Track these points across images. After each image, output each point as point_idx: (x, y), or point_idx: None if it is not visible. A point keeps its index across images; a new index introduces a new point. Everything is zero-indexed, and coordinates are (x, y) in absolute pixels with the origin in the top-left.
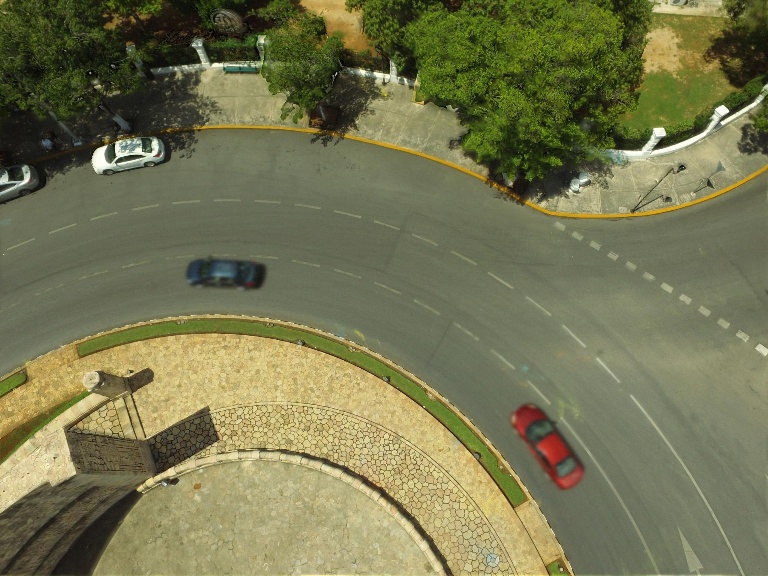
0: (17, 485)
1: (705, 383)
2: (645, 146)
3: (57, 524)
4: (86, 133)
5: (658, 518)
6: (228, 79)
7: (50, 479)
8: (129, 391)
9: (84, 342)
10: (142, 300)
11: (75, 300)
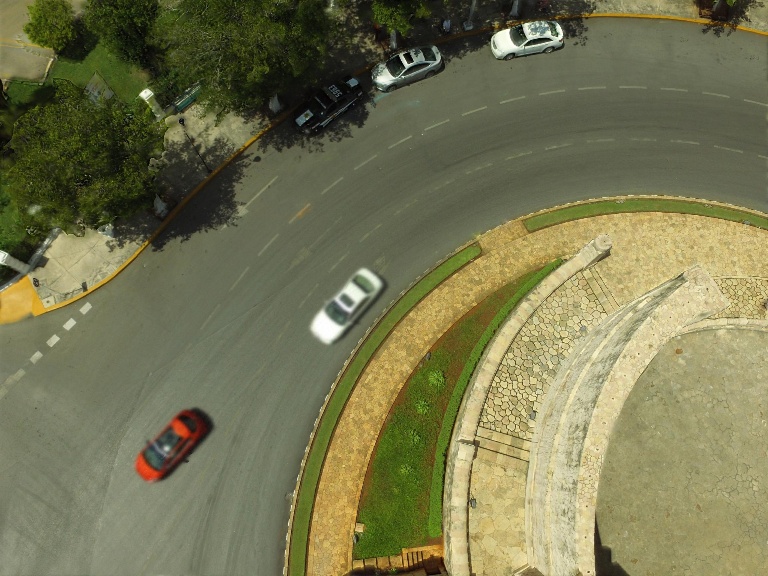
0: (681, 312)
1: None
2: None
3: None
4: (474, 18)
5: None
6: None
7: (709, 308)
8: None
9: (529, 218)
10: (574, 180)
11: (508, 179)
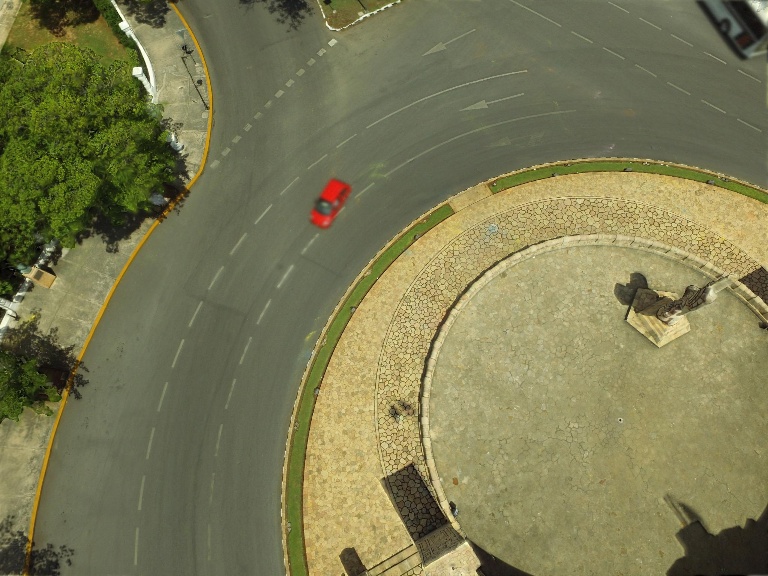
0: None
1: (357, 80)
2: (146, 88)
3: None
4: None
5: (455, 122)
6: None
7: (474, 569)
8: (365, 572)
9: None
10: None
11: None
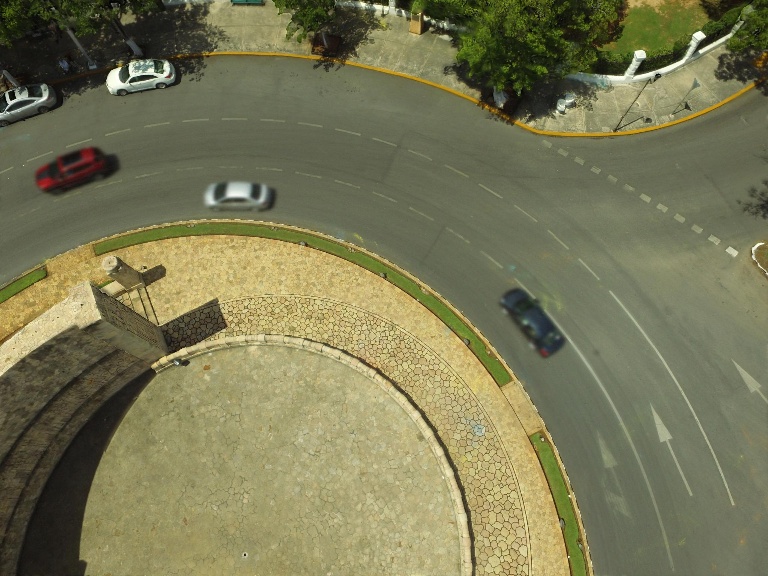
0: (48, 327)
1: (678, 280)
2: (627, 70)
3: (79, 386)
4: (101, 58)
5: (632, 396)
6: (235, 10)
7: (78, 322)
8: (143, 284)
9: (100, 242)
10: (154, 206)
11: (91, 206)
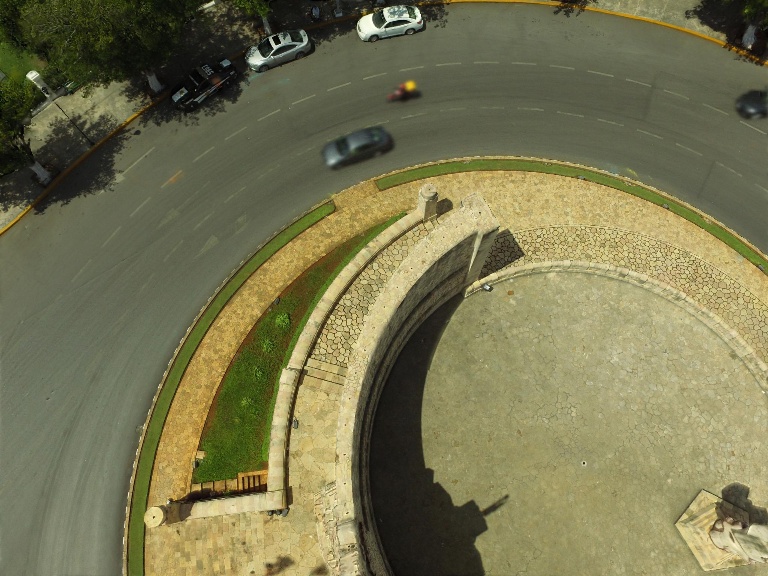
0: (454, 233)
1: None
2: None
3: (427, 302)
4: (345, 6)
5: None
6: None
7: (480, 229)
8: (436, 215)
9: (381, 178)
10: (426, 145)
11: (364, 145)
